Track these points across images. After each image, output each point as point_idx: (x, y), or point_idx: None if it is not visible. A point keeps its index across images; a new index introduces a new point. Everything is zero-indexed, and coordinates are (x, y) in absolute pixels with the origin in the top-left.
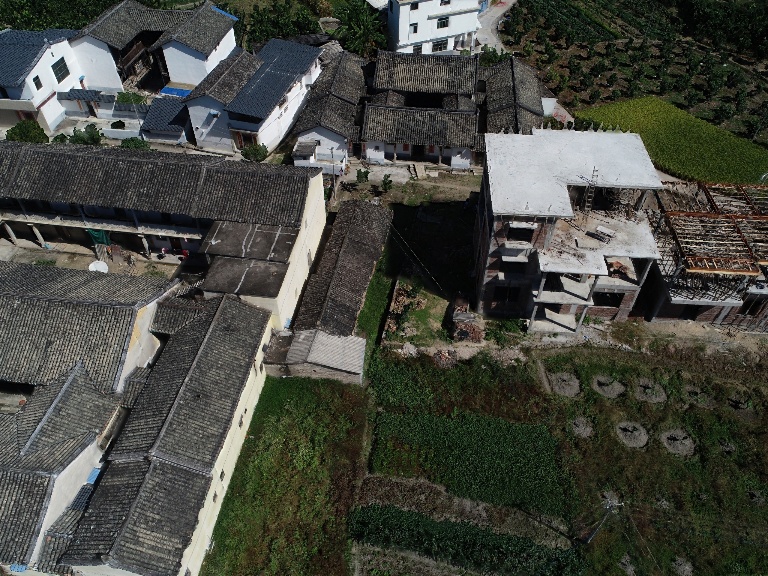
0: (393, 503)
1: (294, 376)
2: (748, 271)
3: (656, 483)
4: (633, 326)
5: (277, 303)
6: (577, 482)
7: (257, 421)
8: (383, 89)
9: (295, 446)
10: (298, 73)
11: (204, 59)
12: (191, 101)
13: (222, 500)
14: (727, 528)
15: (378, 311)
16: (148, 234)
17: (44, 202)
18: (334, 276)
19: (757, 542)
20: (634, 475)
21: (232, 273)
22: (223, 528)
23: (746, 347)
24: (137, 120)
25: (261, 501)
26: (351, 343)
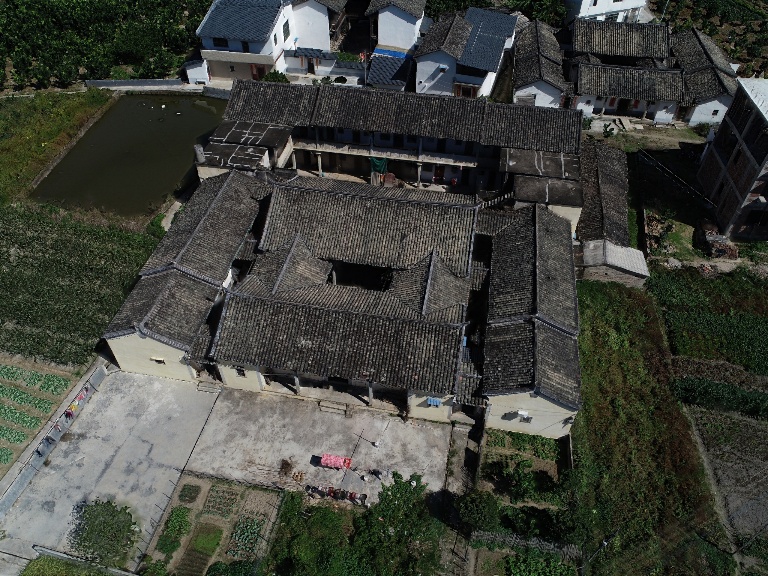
0: (704, 377)
1: (584, 279)
2: None
3: None
4: None
5: None
6: None
7: None
8: (582, 52)
9: (604, 332)
10: (506, 36)
11: (415, 23)
12: (424, 56)
13: None
14: None
15: (633, 234)
16: (427, 162)
17: (329, 134)
18: (603, 199)
19: None
20: None
21: (536, 188)
22: None
23: None
24: (352, 77)
25: (592, 371)
26: (632, 253)
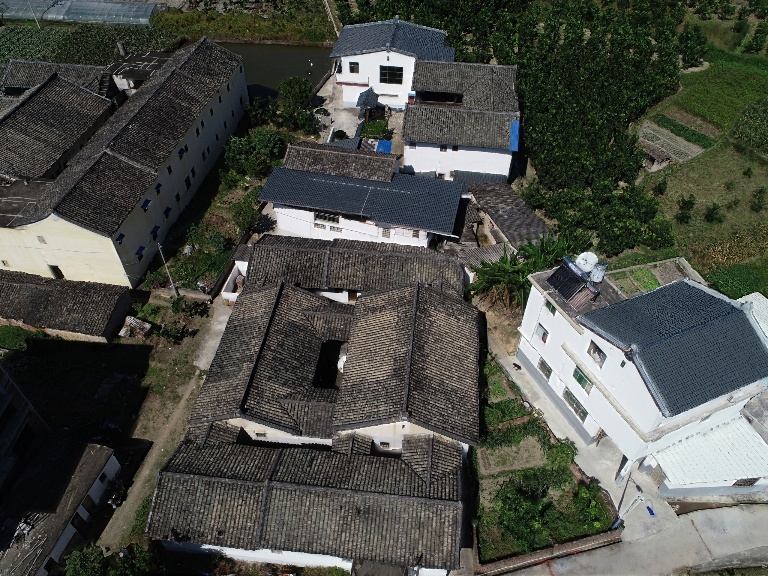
0: None
1: None
2: None
3: None
4: None
5: None
6: None
7: None
8: (355, 308)
9: None
10: (369, 214)
11: (407, 143)
12: None
13: None
14: None
15: None
16: None
17: None
18: None
19: None
20: None
21: None
22: None
23: None
24: None
25: None
26: None
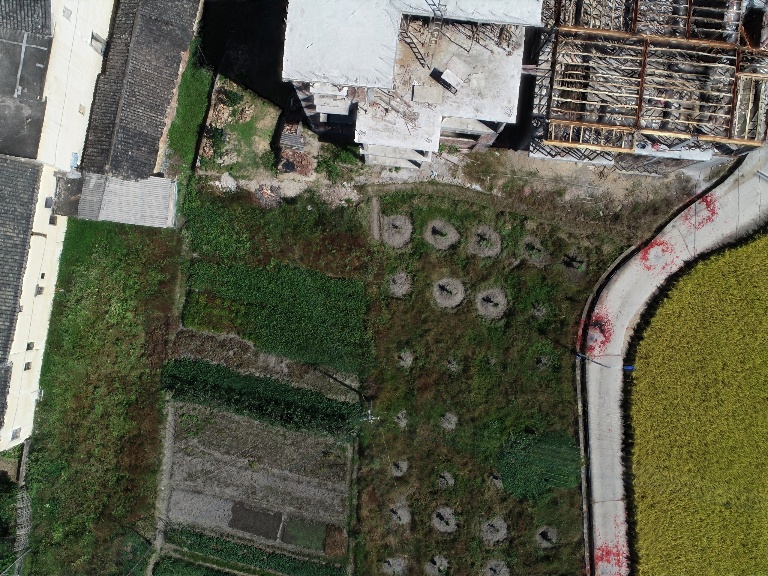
0: (204, 357)
1: None
2: (619, 147)
3: (452, 348)
4: (494, 157)
5: (42, 161)
6: (377, 346)
7: (65, 271)
8: None
9: (108, 298)
10: None
11: None
12: None
13: (42, 356)
14: (501, 391)
15: (195, 121)
16: None
17: None
18: (123, 90)
19: (521, 405)
20: (435, 338)
21: None
22: (48, 380)
23: (612, 194)
24: None
25: (81, 353)
26: (152, 187)
